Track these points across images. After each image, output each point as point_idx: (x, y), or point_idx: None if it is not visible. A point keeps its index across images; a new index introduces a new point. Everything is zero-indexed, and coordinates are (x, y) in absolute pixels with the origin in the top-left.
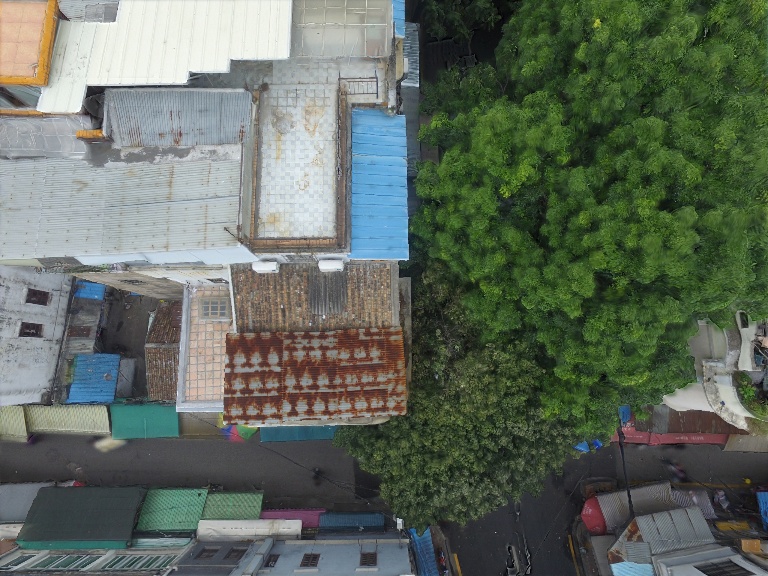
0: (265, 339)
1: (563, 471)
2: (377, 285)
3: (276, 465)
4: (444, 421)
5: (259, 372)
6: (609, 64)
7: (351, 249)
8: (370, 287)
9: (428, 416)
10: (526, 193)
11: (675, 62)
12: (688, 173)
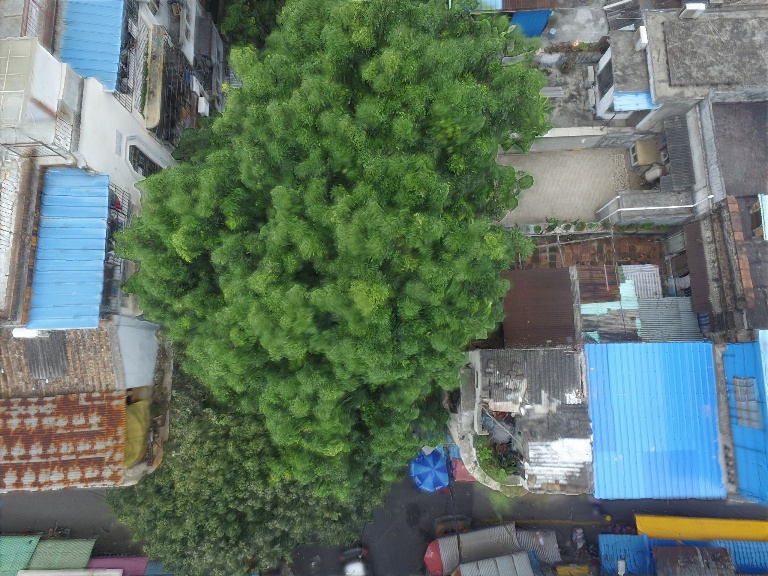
0: None
1: (418, 509)
2: (97, 348)
3: None
4: (181, 486)
5: None
6: (245, 129)
7: (27, 320)
8: (90, 350)
9: (172, 479)
10: None
11: (305, 127)
12: (300, 249)
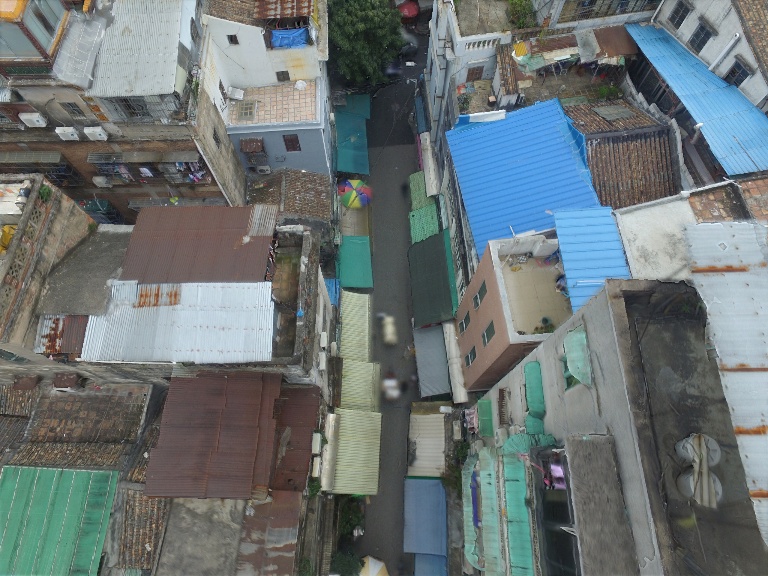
0: (259, 4)
1: None
2: None
3: (395, 195)
4: None
5: (281, 4)
6: None
7: None
8: None
9: None
10: None
11: None
12: None
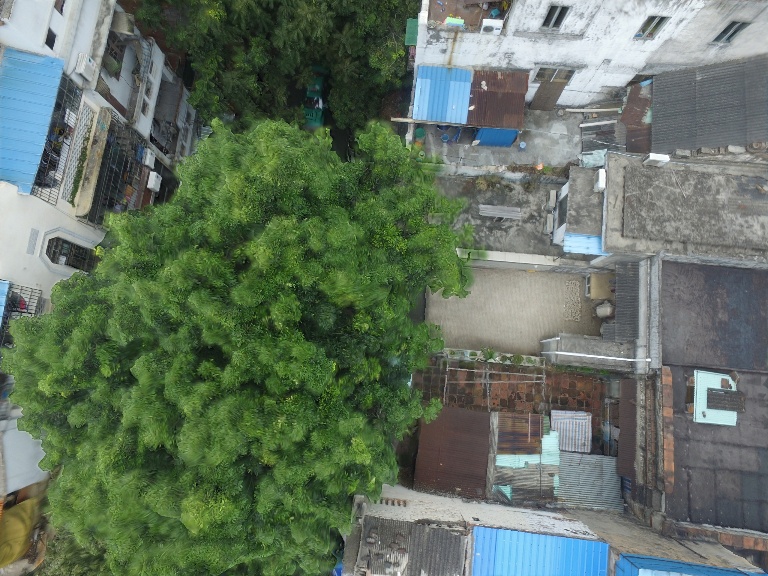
0: None
1: None
2: None
3: None
4: None
5: None
6: None
7: None
8: None
9: None
10: (90, 394)
11: (177, 303)
12: (145, 442)
